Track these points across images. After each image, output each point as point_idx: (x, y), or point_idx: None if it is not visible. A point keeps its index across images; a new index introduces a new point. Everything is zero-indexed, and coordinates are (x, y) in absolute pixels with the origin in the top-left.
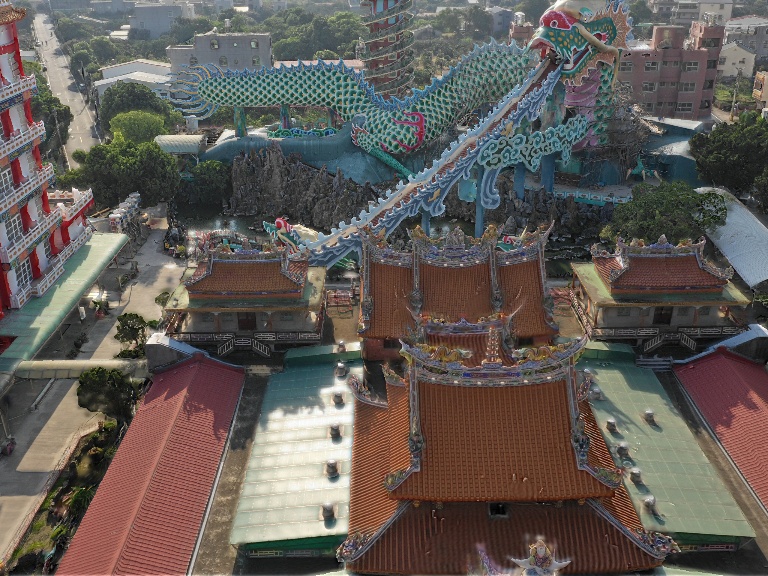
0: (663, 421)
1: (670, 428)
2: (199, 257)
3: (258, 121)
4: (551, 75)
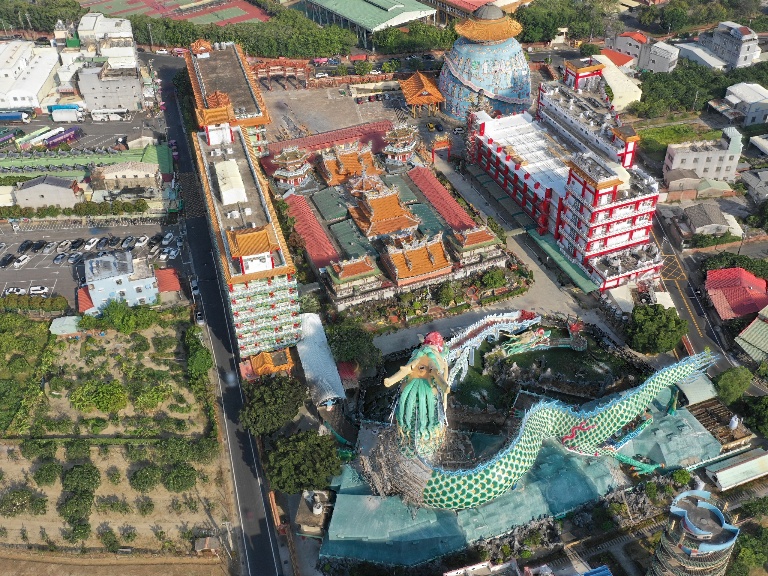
0: (349, 245)
1: (347, 244)
2: (495, 235)
3: (760, 516)
4: None
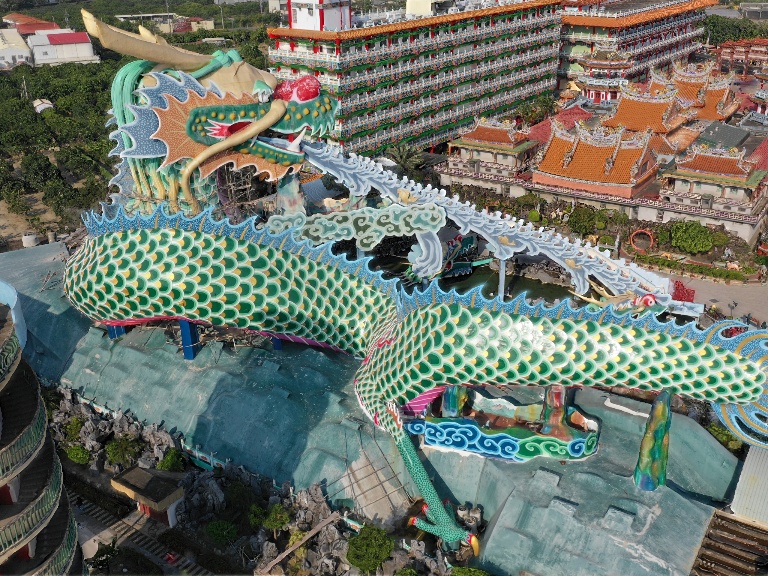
0: None
1: None
2: (749, 170)
3: None
4: (320, 145)
